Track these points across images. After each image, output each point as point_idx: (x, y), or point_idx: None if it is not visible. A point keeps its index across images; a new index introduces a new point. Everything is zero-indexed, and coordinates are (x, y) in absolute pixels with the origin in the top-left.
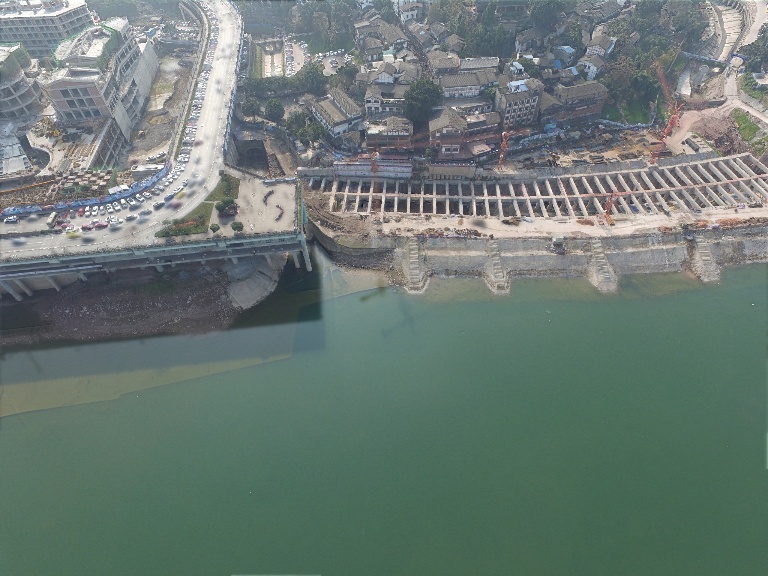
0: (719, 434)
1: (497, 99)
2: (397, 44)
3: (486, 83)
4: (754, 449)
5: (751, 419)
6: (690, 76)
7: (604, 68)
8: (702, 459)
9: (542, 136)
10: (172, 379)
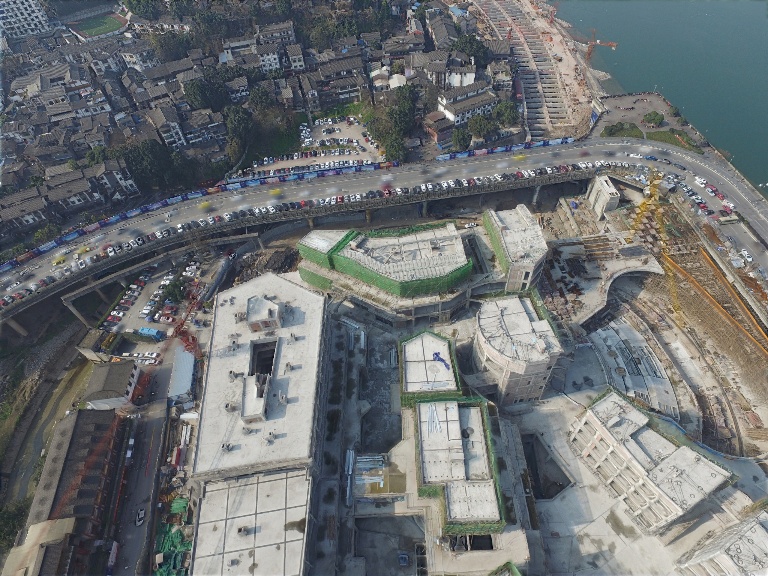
0: (668, 34)
1: (463, 28)
2: None
3: (453, 24)
4: (670, 29)
5: (654, 28)
6: None
7: None
8: (683, 38)
9: None
10: (763, 191)
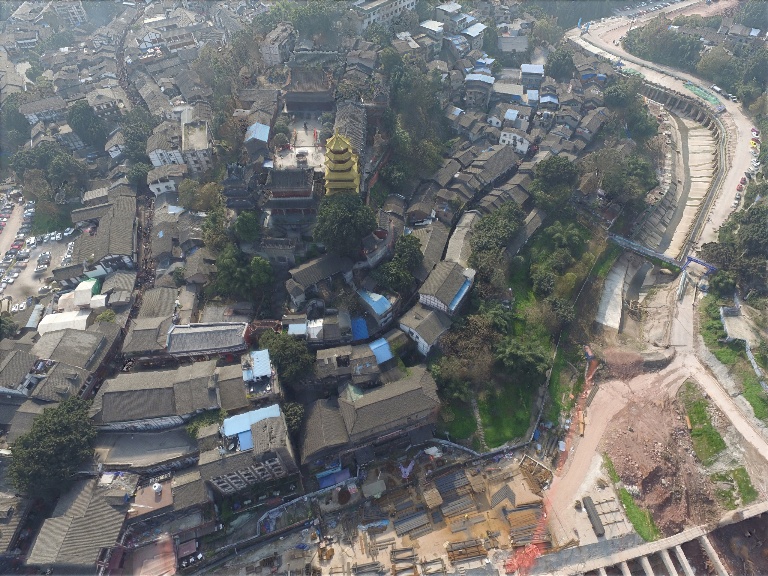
0: None
1: None
2: (108, 261)
3: (187, 412)
4: None
5: None
6: (625, 277)
7: (441, 345)
8: None
9: (311, 494)
10: None
